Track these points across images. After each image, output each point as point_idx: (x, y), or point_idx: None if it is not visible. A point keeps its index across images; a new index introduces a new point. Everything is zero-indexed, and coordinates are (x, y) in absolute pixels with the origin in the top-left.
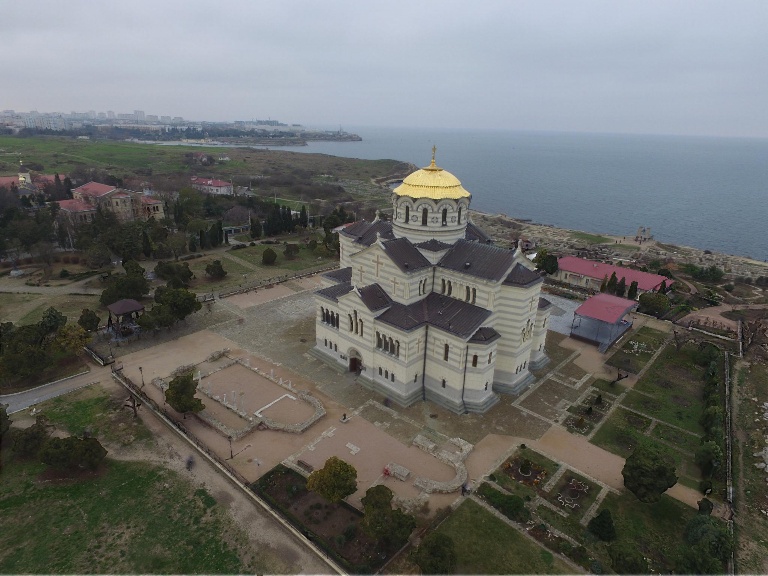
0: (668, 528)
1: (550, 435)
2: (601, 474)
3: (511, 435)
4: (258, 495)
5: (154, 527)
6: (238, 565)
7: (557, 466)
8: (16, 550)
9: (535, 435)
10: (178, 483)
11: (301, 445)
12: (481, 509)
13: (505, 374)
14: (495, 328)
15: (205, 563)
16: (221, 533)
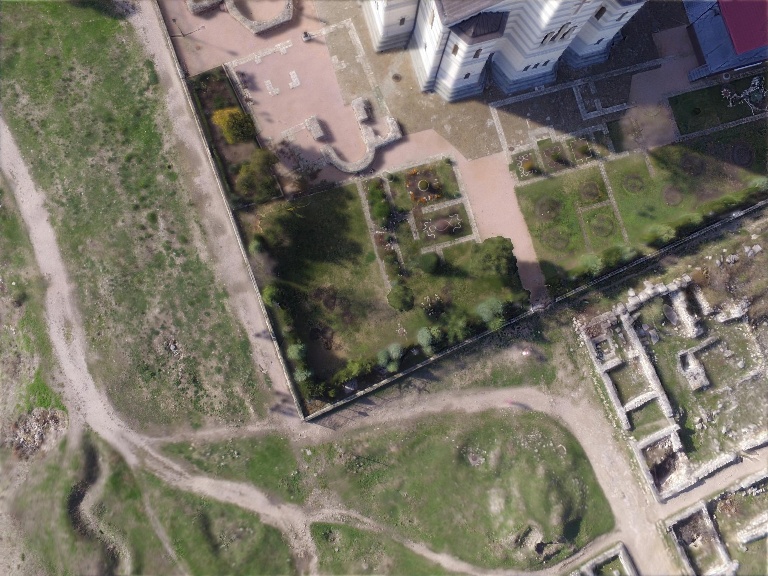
0: (481, 288)
1: (487, 161)
2: (485, 223)
3: (450, 142)
4: (190, 93)
5: (109, 82)
6: (159, 148)
7: (456, 196)
8: (14, 53)
9: (472, 154)
10: (133, 44)
11: (250, 51)
12: (356, 198)
13: (509, 66)
14: (517, 11)
15: (138, 134)
16: (155, 114)
